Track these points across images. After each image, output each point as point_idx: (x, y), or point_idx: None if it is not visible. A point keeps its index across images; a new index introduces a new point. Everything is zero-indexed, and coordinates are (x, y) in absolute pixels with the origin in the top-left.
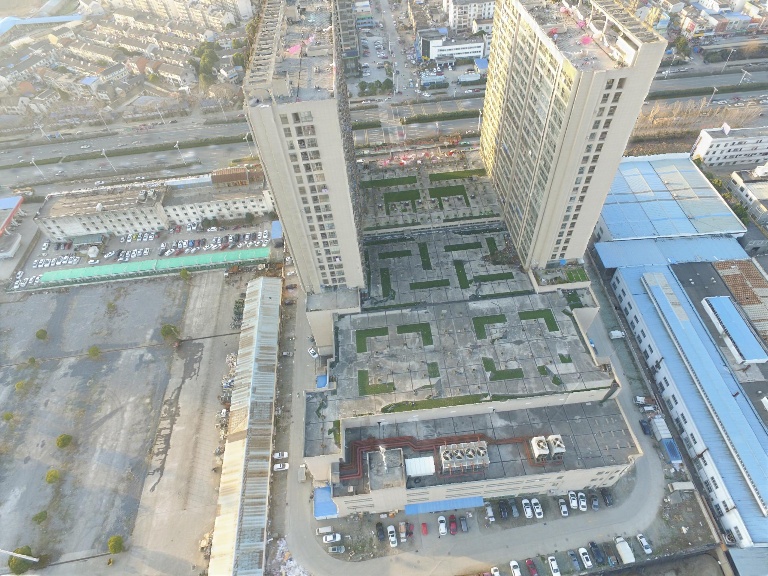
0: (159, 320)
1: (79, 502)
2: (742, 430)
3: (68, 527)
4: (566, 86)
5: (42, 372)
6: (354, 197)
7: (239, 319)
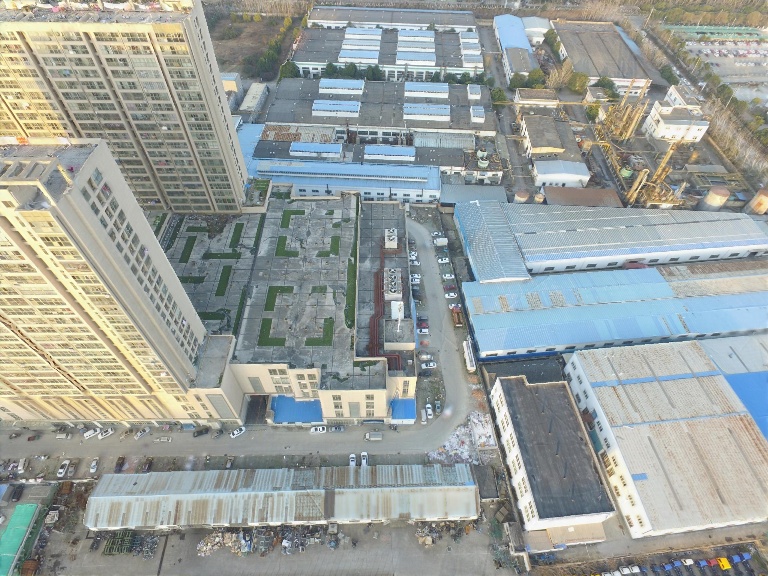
0: None
1: None
2: (383, 169)
3: None
4: (175, 42)
5: None
6: None
7: (141, 545)
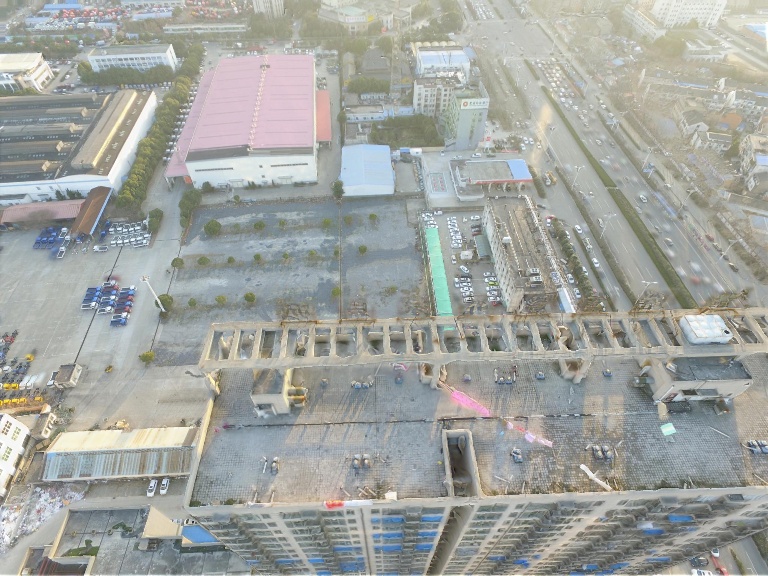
0: None
1: (199, 323)
2: None
3: (183, 322)
4: None
5: (328, 263)
6: (324, 573)
7: None
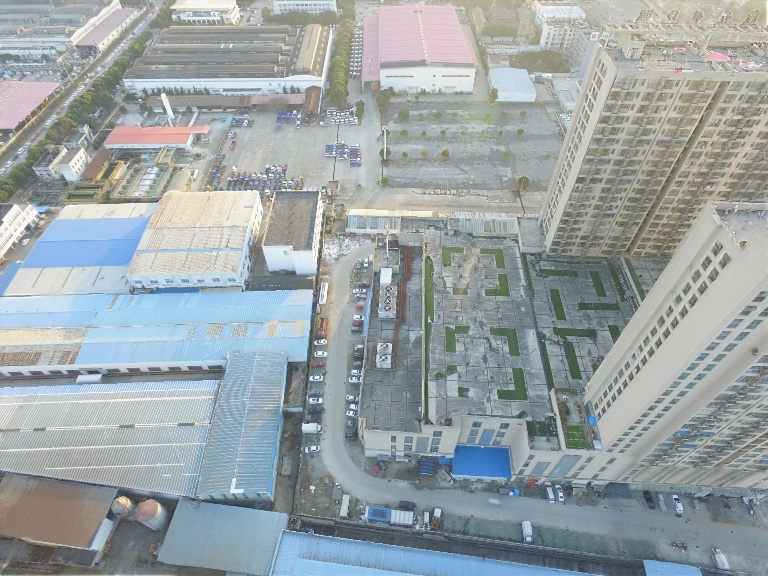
0: (537, 180)
1: (411, 168)
2: None
3: (399, 166)
4: None
5: (494, 140)
6: (607, 188)
7: None
